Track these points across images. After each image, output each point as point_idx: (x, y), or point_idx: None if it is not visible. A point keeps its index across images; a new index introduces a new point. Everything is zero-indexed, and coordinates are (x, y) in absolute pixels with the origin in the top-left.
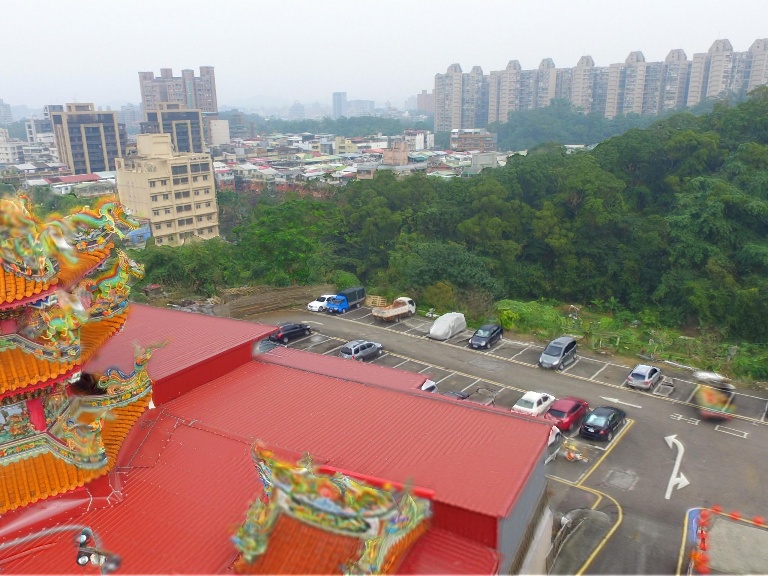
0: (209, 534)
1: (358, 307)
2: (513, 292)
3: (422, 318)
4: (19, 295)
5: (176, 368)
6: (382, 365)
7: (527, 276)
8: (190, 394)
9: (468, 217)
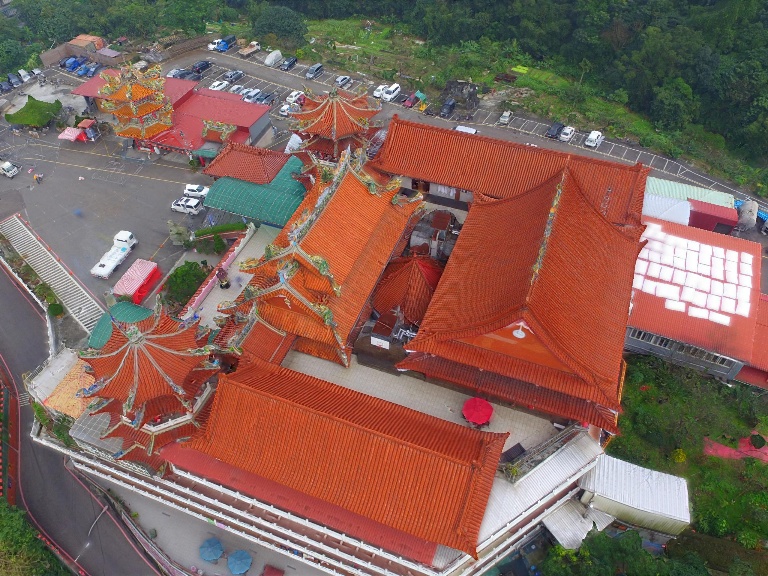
0: (196, 135)
1: (233, 46)
2: (336, 12)
3: (264, 52)
4: (151, 93)
5: (176, 100)
6: (243, 82)
7: (344, 0)
8: (181, 106)
9: None
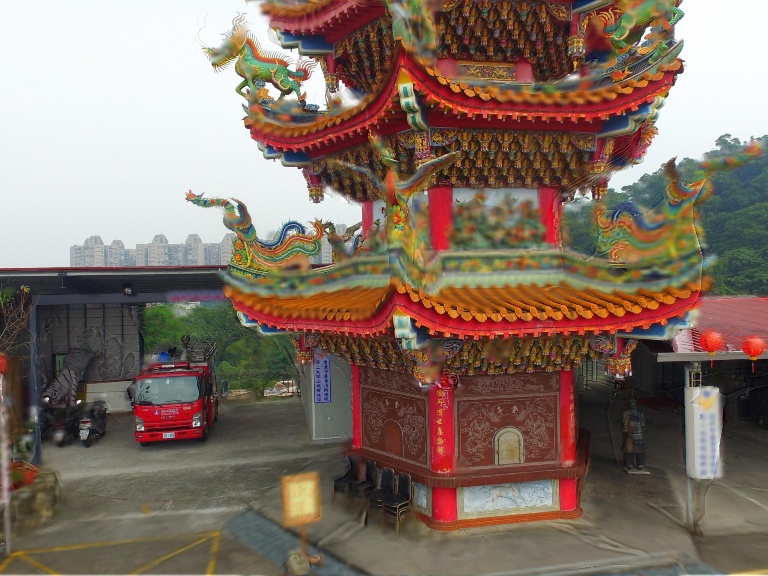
0: None
1: None
2: None
3: None
4: None
5: None
6: None
7: None
8: None
9: (233, 341)
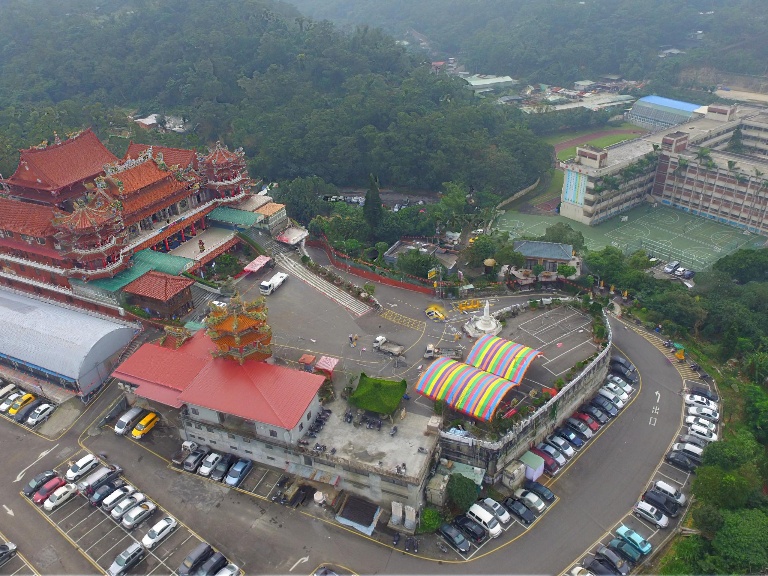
0: None
1: None
2: None
3: None
4: None
5: None
6: (118, 553)
7: None
8: None
9: None
